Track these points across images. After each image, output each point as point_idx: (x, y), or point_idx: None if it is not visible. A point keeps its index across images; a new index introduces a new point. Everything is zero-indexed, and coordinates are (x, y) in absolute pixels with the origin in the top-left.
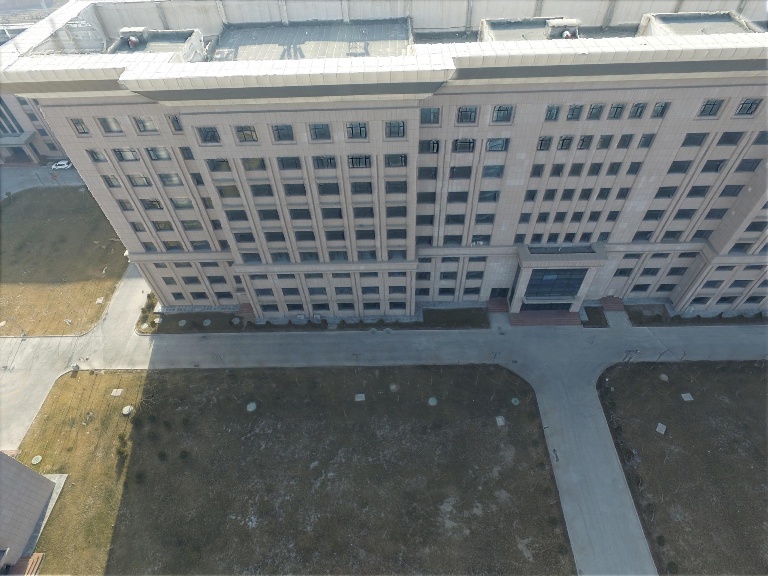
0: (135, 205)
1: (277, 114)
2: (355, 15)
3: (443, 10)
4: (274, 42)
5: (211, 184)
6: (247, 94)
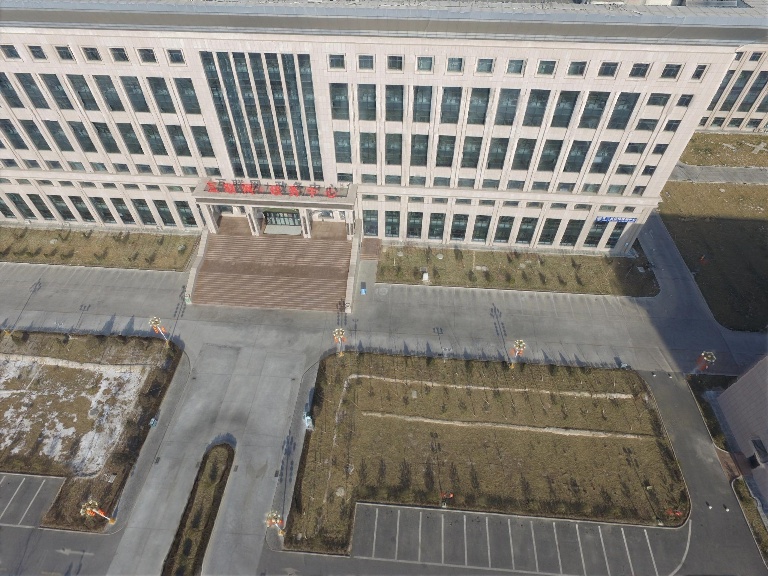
0: None
1: None
2: None
3: None
4: None
5: None
6: None
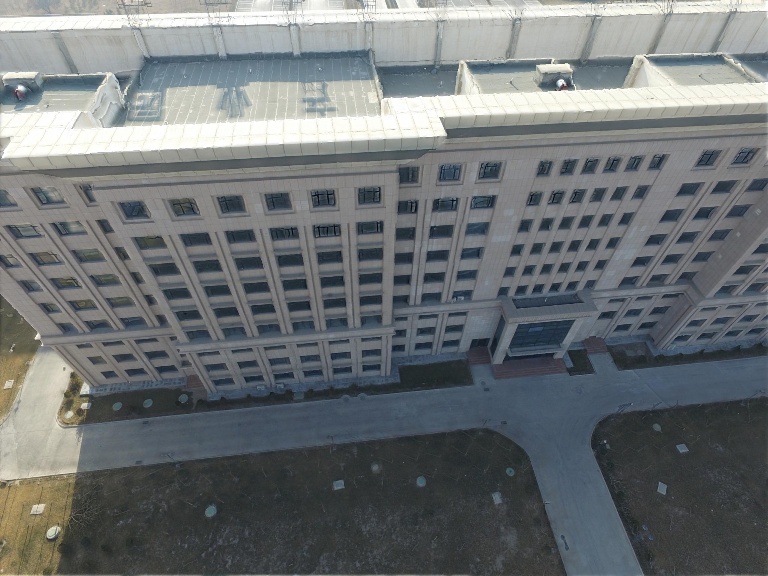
0: (44, 285)
1: (224, 185)
2: (307, 47)
3: (409, 42)
4: (211, 82)
5: (142, 263)
6: (184, 167)
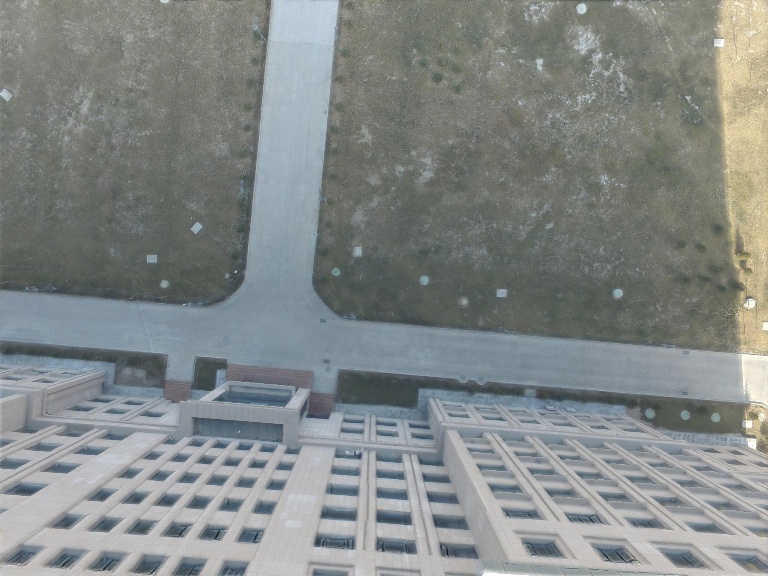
0: None
1: None
2: None
3: None
4: None
5: None
6: None
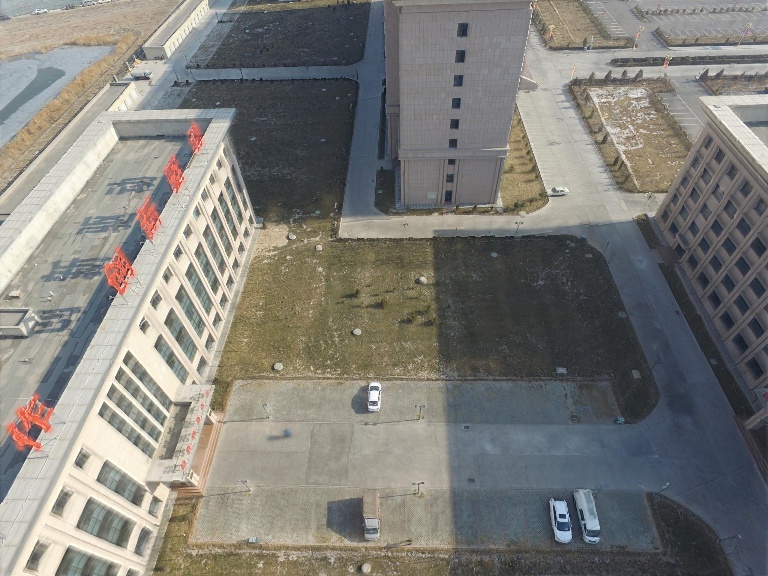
0: None
1: None
2: None
3: None
4: None
5: None
6: None
